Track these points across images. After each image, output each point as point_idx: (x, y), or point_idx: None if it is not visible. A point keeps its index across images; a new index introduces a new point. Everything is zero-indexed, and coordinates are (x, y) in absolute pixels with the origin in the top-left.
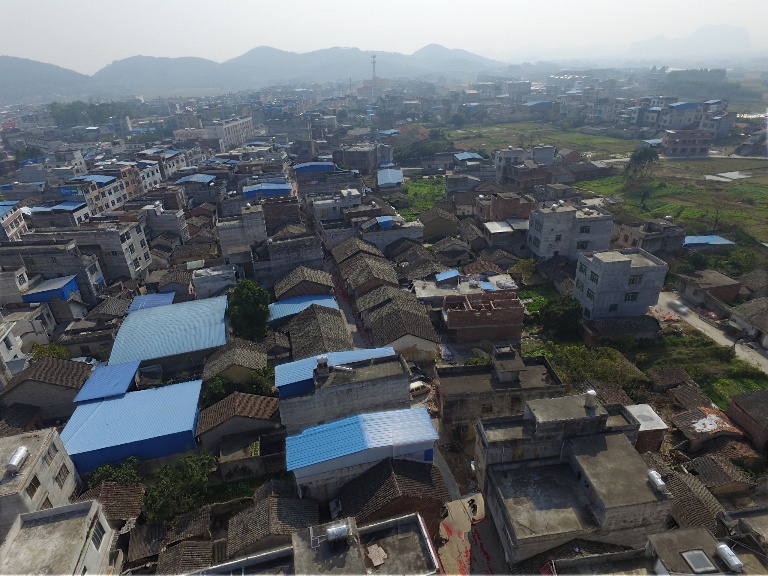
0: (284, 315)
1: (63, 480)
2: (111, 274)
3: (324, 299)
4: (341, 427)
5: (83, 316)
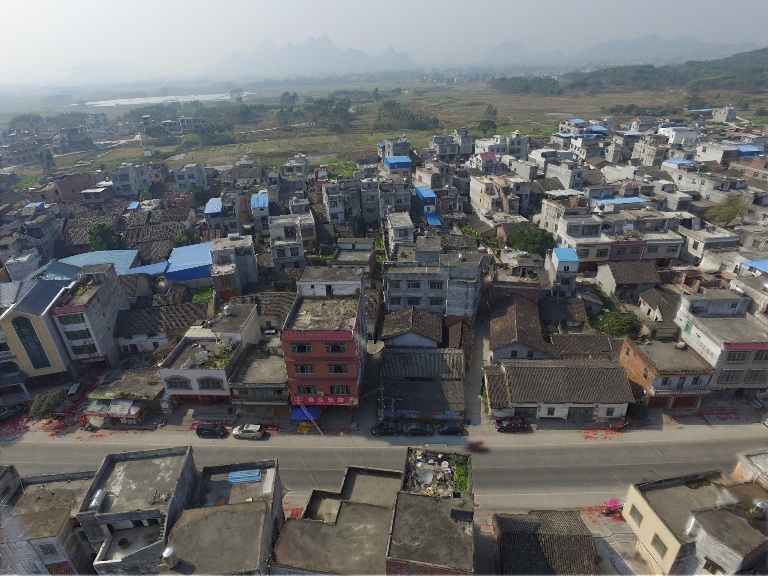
0: None
1: None
2: None
3: None
4: (255, 200)
5: None
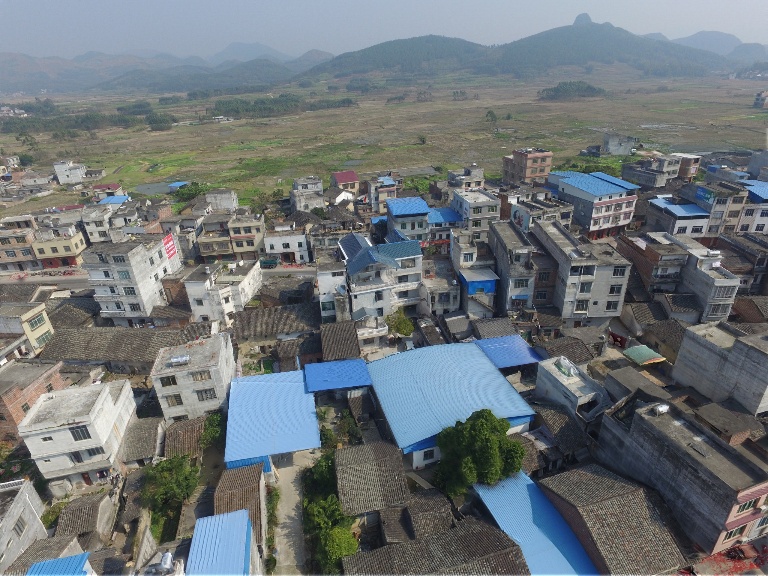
0: (490, 506)
1: (208, 398)
2: (555, 299)
3: (577, 572)
4: None
5: (483, 317)
